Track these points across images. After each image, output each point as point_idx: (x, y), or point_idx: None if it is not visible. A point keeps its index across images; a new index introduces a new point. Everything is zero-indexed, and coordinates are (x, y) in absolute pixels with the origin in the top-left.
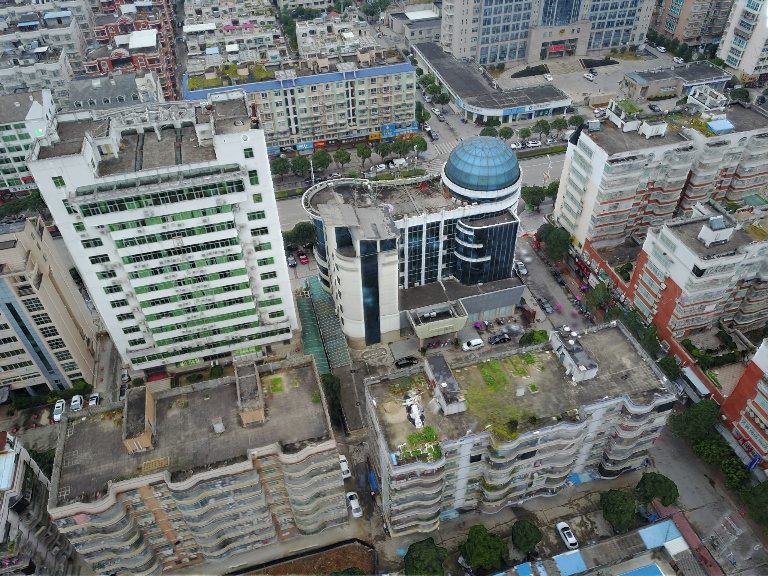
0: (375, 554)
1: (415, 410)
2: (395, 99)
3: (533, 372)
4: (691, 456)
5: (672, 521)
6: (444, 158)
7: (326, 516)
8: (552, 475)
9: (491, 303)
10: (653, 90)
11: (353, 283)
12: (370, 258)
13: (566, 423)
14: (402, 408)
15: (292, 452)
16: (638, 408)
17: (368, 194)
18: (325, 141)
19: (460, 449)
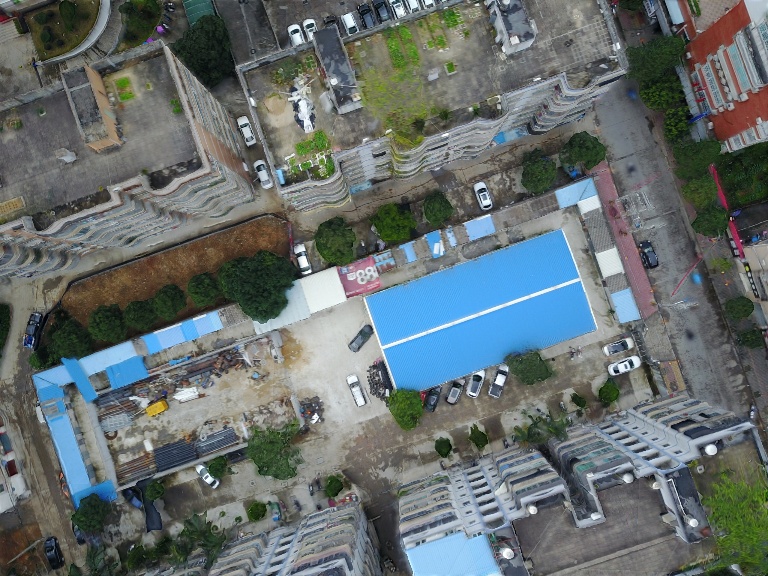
0: (288, 227)
1: (303, 108)
2: None
3: (454, 40)
4: (638, 94)
5: (592, 179)
6: None
7: (229, 204)
8: (470, 149)
9: None
10: None
11: None
12: None
13: (482, 120)
14: (288, 105)
15: (161, 182)
16: (574, 91)
17: None
18: None
19: (358, 153)
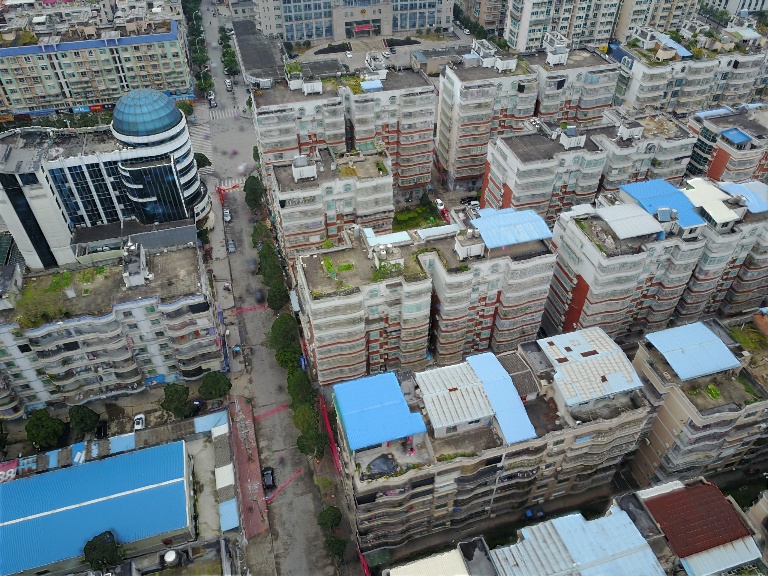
0: None
1: None
2: (163, 67)
3: (97, 280)
4: None
5: (226, 411)
6: (213, 123)
7: None
8: (117, 370)
9: (166, 241)
10: (433, 67)
11: (8, 215)
12: (16, 191)
13: (89, 316)
14: None
15: None
16: (162, 306)
17: (48, 140)
18: (101, 105)
19: (0, 338)
